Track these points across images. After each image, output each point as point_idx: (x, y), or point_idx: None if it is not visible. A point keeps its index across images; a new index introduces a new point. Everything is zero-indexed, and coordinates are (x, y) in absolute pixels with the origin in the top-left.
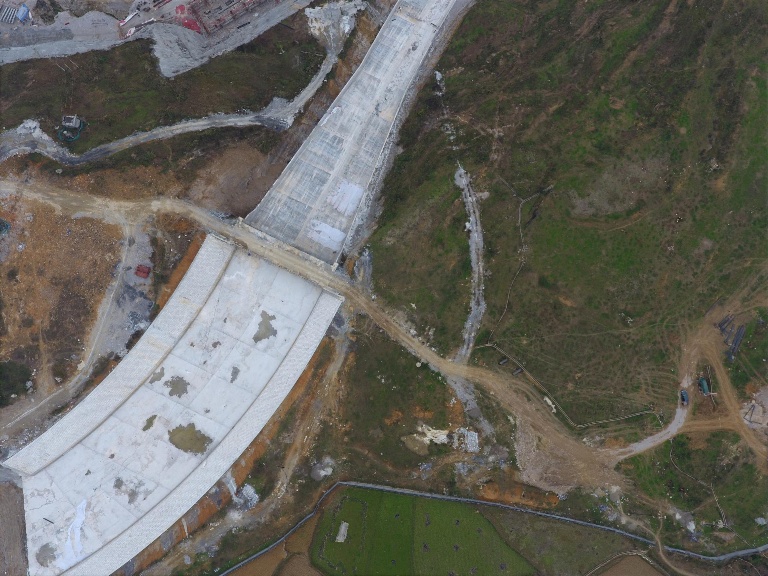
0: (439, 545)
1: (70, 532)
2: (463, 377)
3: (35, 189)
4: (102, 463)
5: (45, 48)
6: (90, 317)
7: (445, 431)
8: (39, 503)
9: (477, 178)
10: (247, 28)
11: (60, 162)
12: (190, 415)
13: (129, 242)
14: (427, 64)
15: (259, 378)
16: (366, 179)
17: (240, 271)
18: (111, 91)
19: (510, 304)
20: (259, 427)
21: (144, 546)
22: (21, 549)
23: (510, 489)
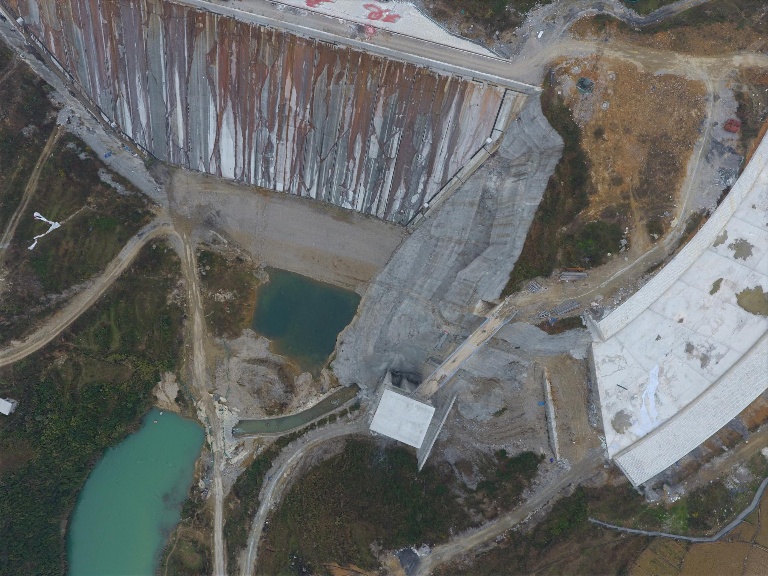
0: None
1: (644, 398)
2: None
3: (615, 48)
4: (672, 328)
5: None
6: (680, 173)
7: None
8: (611, 369)
9: None
10: None
11: None
12: (757, 277)
13: (714, 97)
14: None
15: None
16: None
17: None
18: None
19: None
20: None
21: (747, 403)
22: (587, 419)
23: None
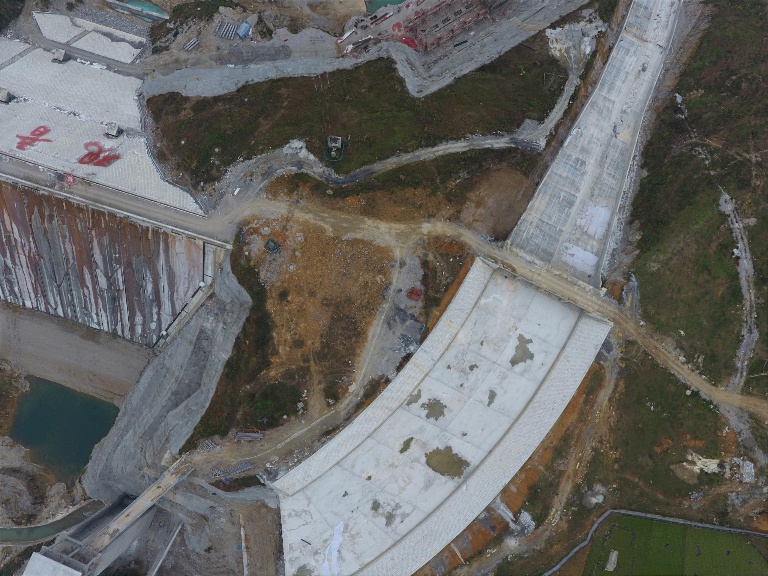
0: (710, 575)
1: (327, 554)
2: (737, 406)
3: (306, 210)
4: (359, 485)
5: (290, 67)
6: (361, 339)
7: (716, 460)
8: (296, 524)
9: (742, 204)
10: (475, 47)
11: (326, 182)
12: (447, 438)
13: (400, 264)
14: (659, 86)
15: (516, 402)
16: (612, 202)
17: (497, 294)
18: (364, 111)
19: None
20: (528, 453)
21: (413, 571)
22: (274, 569)
23: None
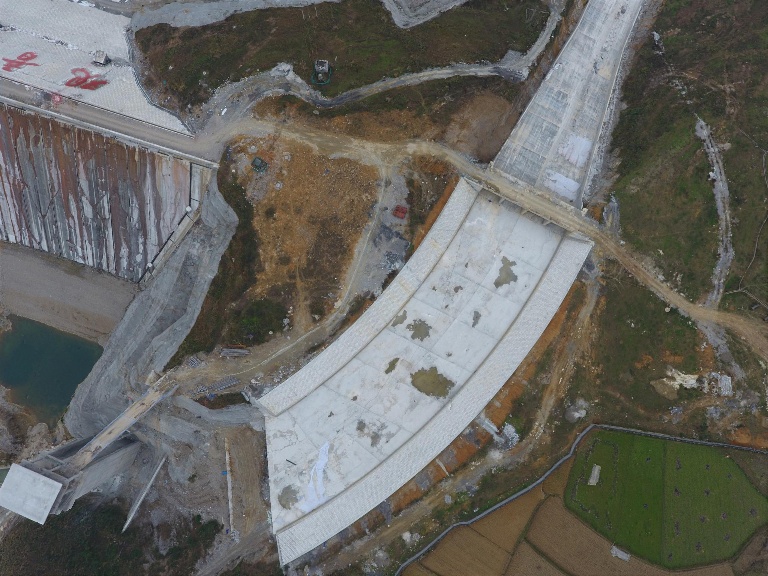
0: (690, 489)
1: (313, 474)
2: (714, 322)
3: (293, 129)
4: (345, 405)
5: None
6: (347, 256)
7: (695, 376)
8: (282, 444)
9: (717, 130)
10: None
11: (313, 105)
12: (432, 358)
13: (386, 183)
14: (638, 26)
15: (500, 323)
16: (592, 133)
17: (481, 217)
18: (351, 40)
19: (759, 251)
20: (512, 369)
21: (398, 486)
22: (259, 492)
23: (761, 434)
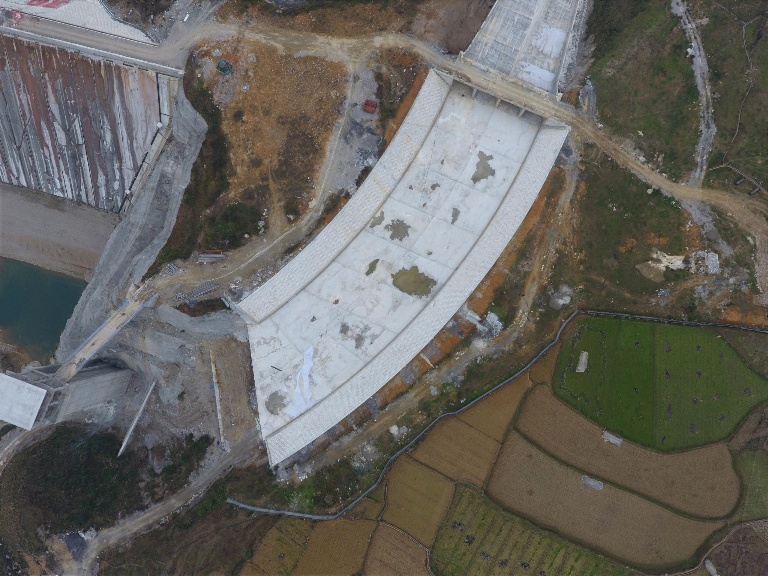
0: (681, 371)
1: (298, 379)
2: (698, 200)
3: (256, 30)
4: (327, 309)
5: None
6: (319, 155)
7: (681, 256)
8: (266, 351)
9: (694, 6)
10: None
11: (276, 5)
12: (413, 258)
13: (354, 78)
14: None
15: (480, 218)
16: (566, 23)
17: (455, 112)
18: None
19: (742, 125)
20: (492, 260)
21: (384, 383)
22: (247, 401)
23: (752, 311)
